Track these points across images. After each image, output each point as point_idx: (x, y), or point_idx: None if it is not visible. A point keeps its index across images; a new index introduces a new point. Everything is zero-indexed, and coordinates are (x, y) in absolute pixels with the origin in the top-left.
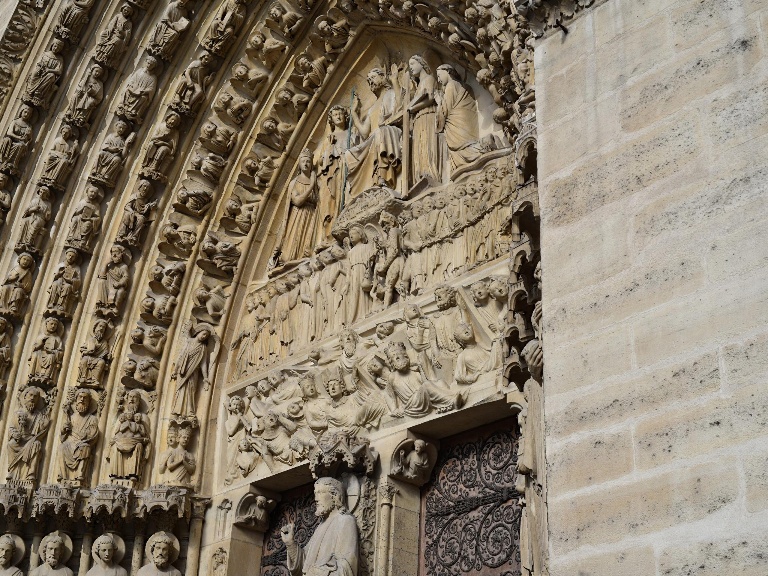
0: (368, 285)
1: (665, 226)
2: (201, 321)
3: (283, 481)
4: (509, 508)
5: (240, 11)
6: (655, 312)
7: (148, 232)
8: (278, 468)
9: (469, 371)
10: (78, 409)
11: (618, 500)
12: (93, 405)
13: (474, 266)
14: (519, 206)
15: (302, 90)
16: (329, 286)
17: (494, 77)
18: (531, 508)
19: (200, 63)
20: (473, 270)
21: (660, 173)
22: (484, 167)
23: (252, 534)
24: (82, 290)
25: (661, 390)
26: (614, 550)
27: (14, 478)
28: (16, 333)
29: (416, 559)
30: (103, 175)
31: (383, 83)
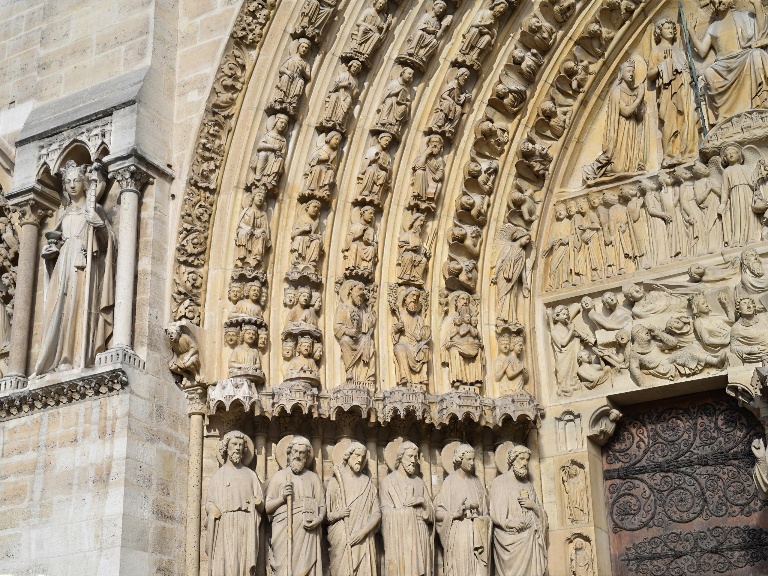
0: (764, 207)
1: None
2: (515, 225)
3: (642, 395)
4: None
5: None
6: None
7: (459, 124)
8: (652, 382)
9: None
10: (410, 308)
11: None
12: (417, 305)
13: None
14: None
15: None
16: (693, 203)
17: None
18: None
19: None
20: None
21: None
22: None
23: (596, 447)
24: (392, 179)
25: None
26: None
27: (354, 378)
28: (321, 219)
29: None
30: (421, 57)
31: (730, 4)
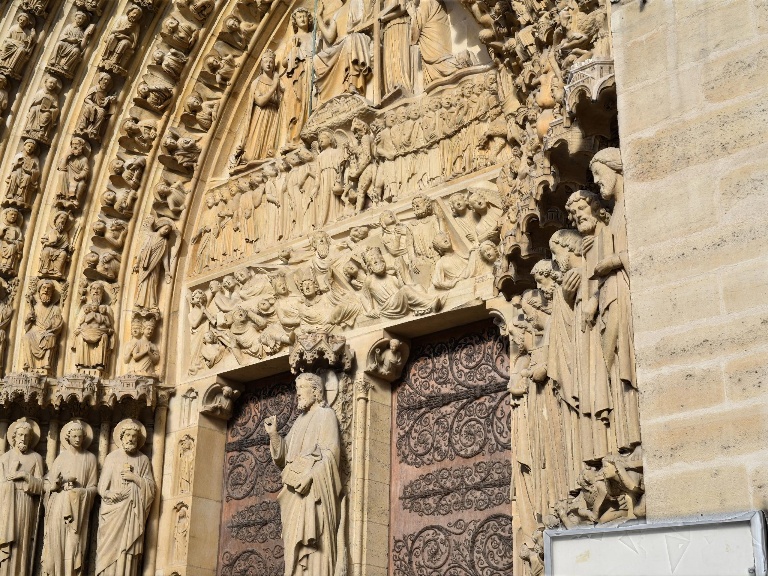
0: (340, 189)
1: (751, 191)
2: (162, 215)
3: (250, 373)
4: (482, 404)
5: None
6: (743, 266)
7: (107, 125)
8: (247, 361)
9: (447, 277)
10: (42, 299)
11: (710, 425)
12: (56, 296)
13: (451, 178)
14: (554, 143)
15: None
16: (297, 187)
17: (485, 0)
18: (543, 413)
19: None
20: (450, 181)
21: (745, 143)
22: (460, 82)
23: (217, 422)
24: (41, 181)
25: (750, 334)
26: (708, 467)
27: None
28: None
29: (389, 449)
30: (62, 66)
31: None
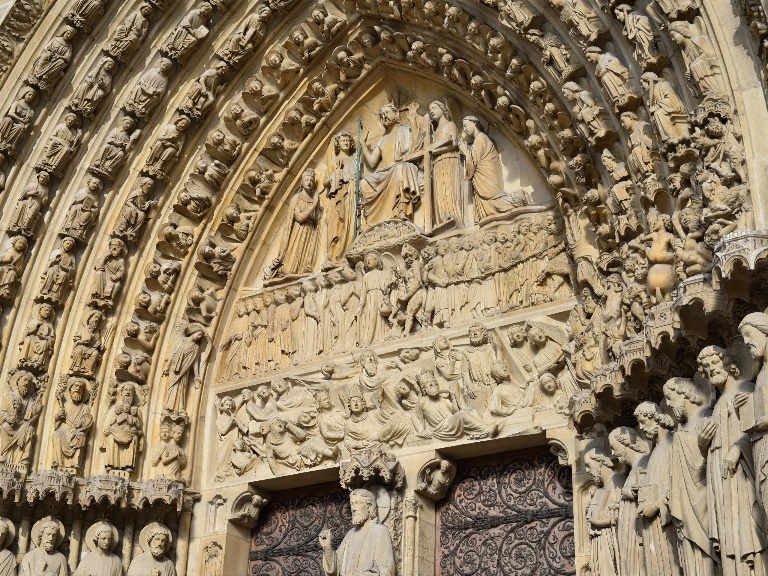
0: (388, 311)
1: None
2: (194, 321)
3: (281, 483)
4: (533, 529)
5: (261, 29)
6: None
7: (145, 229)
8: (283, 471)
9: (503, 404)
10: (73, 397)
11: None
12: (85, 394)
13: (508, 310)
14: (689, 300)
15: (310, 112)
16: (339, 305)
17: (563, 150)
18: (651, 547)
19: (216, 72)
20: (507, 313)
21: None
22: (516, 220)
23: (242, 530)
24: (75, 279)
25: None
26: None
27: (8, 462)
28: (4, 315)
29: (433, 567)
30: (107, 168)
31: (396, 119)
